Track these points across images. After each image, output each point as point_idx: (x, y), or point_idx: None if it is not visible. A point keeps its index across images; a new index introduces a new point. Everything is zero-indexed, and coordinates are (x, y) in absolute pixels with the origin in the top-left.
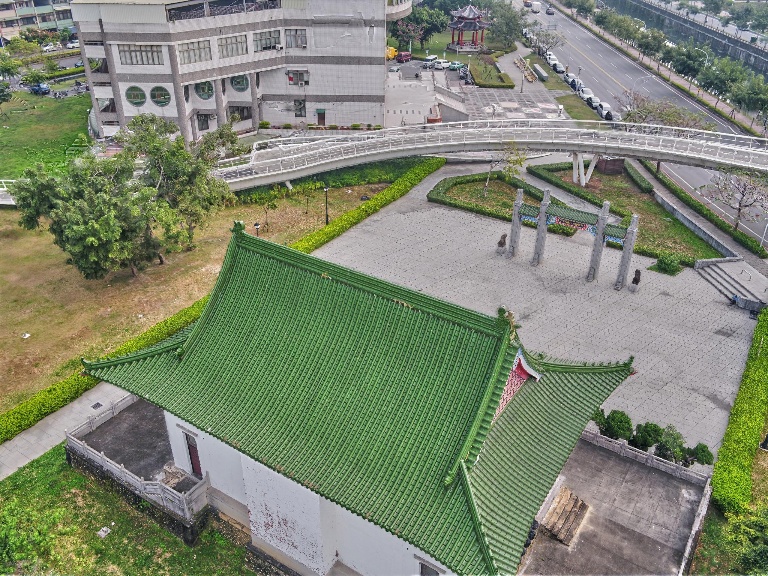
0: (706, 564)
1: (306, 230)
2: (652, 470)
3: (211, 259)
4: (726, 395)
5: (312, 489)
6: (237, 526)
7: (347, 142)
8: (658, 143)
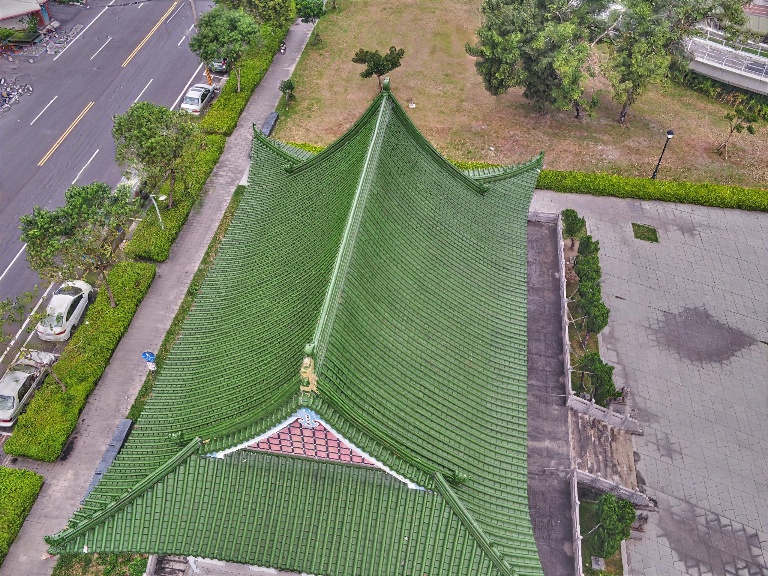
0: None
1: None
2: None
3: (622, 143)
4: None
5: None
6: None
7: None
8: None
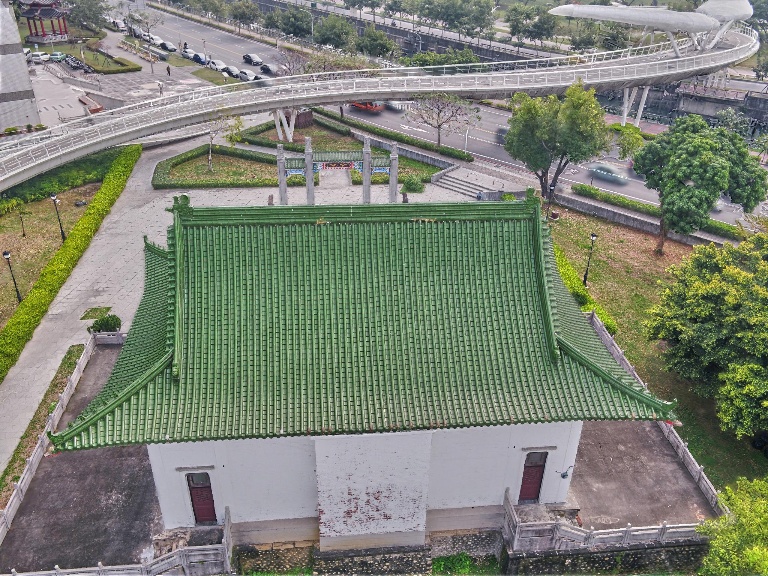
0: None
1: (40, 253)
2: None
3: None
4: None
5: (442, 427)
6: (286, 546)
7: (23, 147)
8: (348, 86)
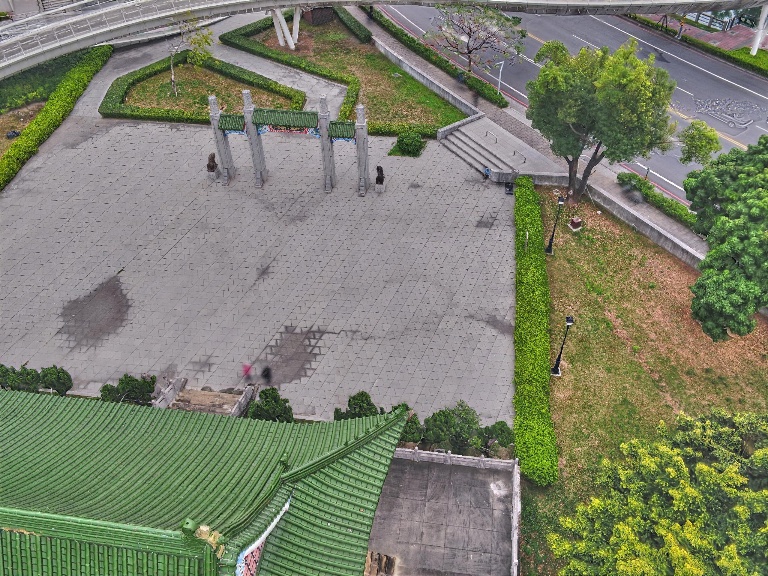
0: (532, 564)
1: None
2: (453, 469)
3: None
4: (505, 312)
5: None
6: None
7: None
8: None
